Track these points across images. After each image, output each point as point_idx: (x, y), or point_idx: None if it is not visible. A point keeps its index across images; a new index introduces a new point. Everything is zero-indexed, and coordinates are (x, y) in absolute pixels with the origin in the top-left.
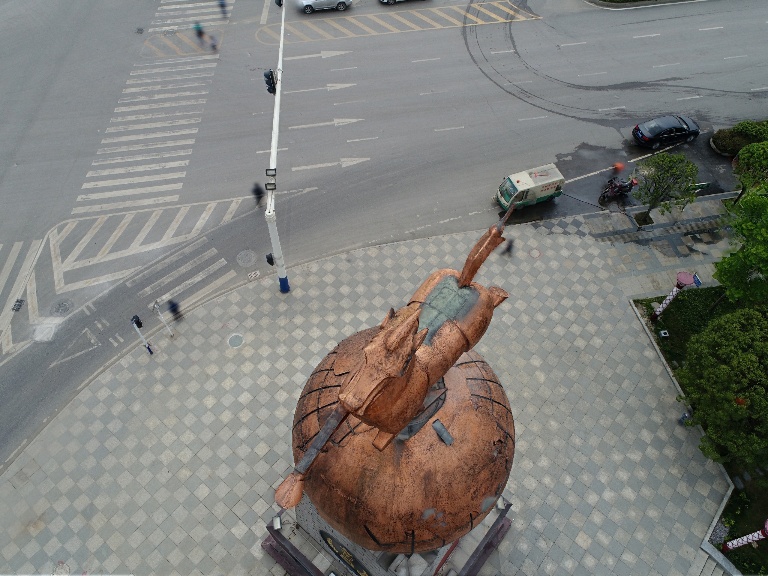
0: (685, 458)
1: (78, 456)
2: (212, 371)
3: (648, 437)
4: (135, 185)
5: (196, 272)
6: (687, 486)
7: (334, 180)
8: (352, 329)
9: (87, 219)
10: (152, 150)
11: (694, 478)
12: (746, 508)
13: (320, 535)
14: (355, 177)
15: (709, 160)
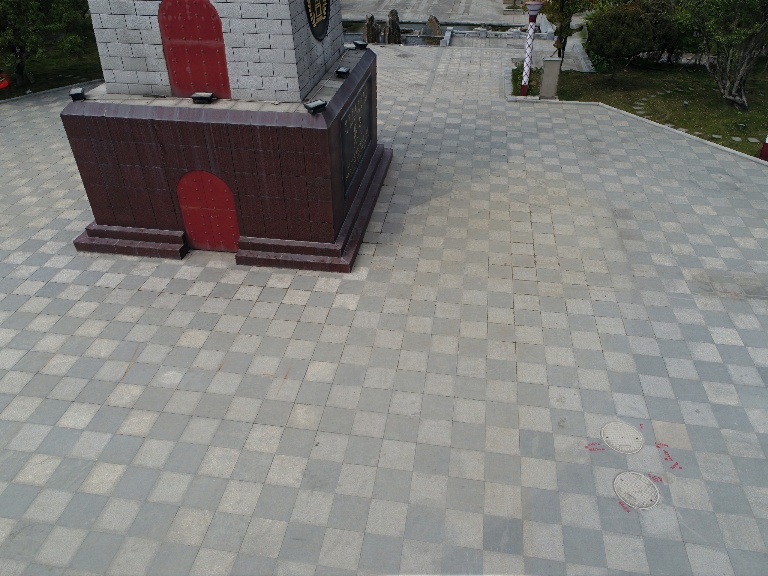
0: None
1: None
2: None
3: (59, 109)
4: None
5: None
6: None
7: None
8: None
9: None
10: None
11: None
12: None
13: (306, 18)
14: None
15: None
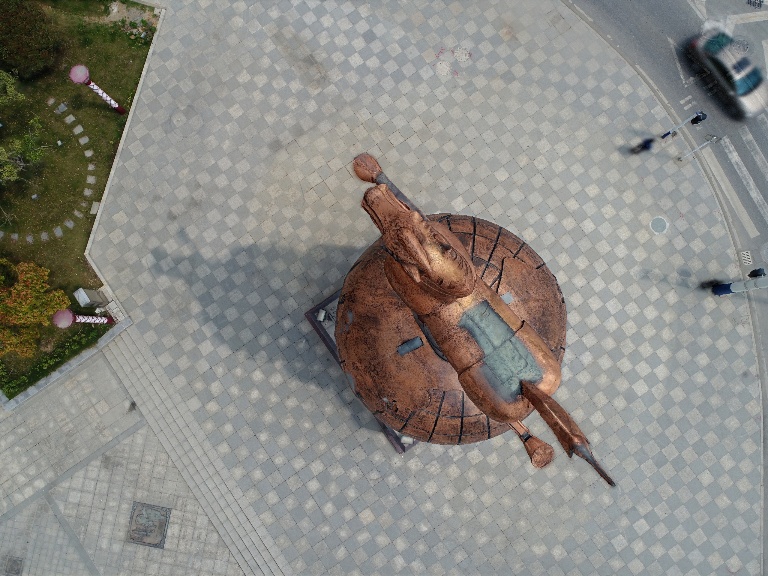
0: None
1: (564, 67)
2: (627, 196)
3: None
4: None
5: (764, 192)
6: None
7: None
8: (646, 355)
9: None
10: None
11: None
12: None
13: None
14: None
15: None
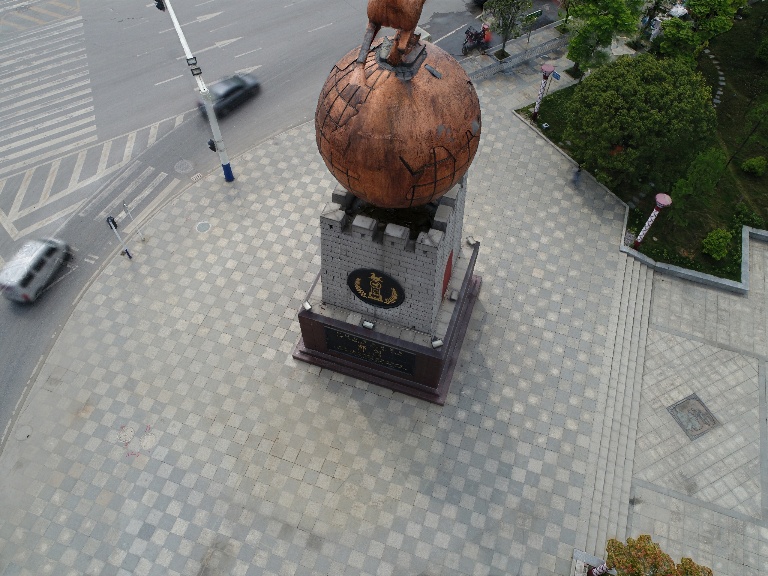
0: (589, 200)
1: (99, 350)
2: (193, 254)
3: (559, 195)
4: (49, 138)
5: (142, 189)
6: (597, 217)
7: (236, 89)
8: (301, 191)
9: (14, 176)
10: (52, 106)
11: (600, 210)
12: (642, 218)
13: (348, 287)
14: (254, 82)
15: (535, 3)
